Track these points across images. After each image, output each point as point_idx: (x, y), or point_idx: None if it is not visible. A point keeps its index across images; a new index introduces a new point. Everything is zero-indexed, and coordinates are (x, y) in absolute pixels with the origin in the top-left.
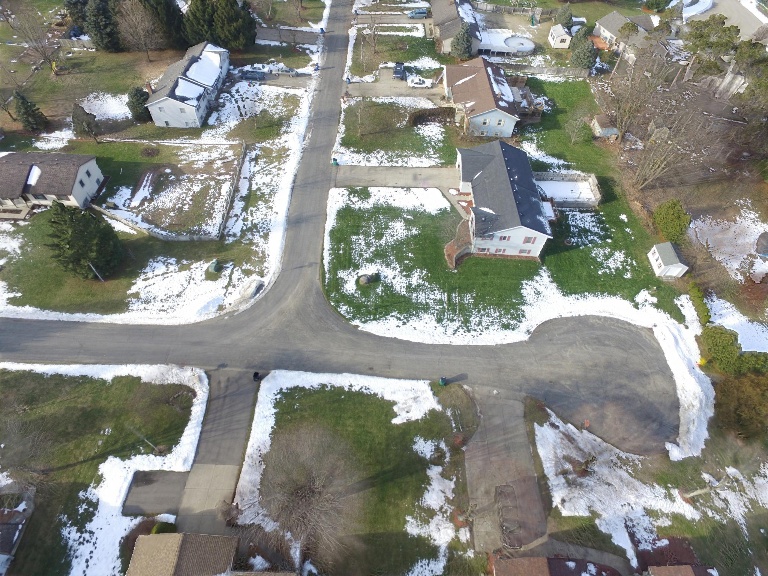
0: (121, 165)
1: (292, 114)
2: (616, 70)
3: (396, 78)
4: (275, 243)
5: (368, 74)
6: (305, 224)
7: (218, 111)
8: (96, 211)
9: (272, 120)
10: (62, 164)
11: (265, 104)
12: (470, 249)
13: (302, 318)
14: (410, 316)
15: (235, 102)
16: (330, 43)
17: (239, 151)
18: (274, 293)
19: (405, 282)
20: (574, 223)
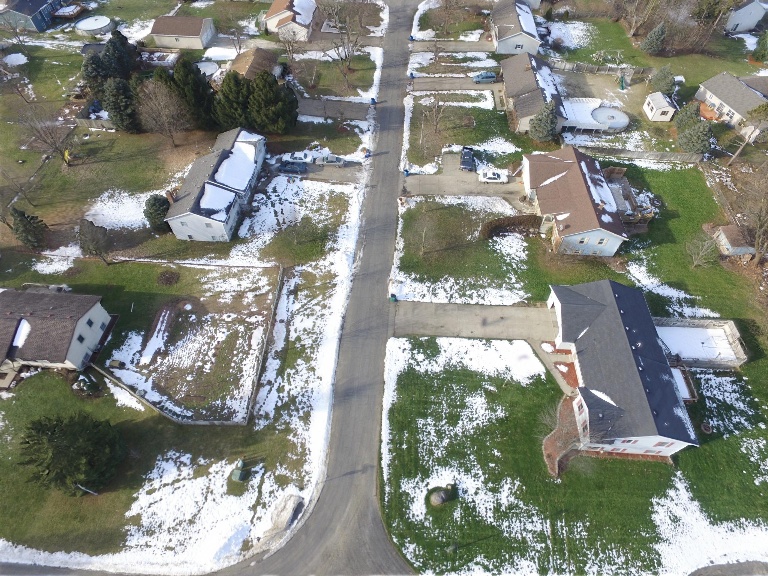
0: (133, 298)
1: (339, 222)
2: (734, 153)
3: (464, 170)
4: (318, 430)
5: (429, 162)
6: (357, 398)
7: (251, 217)
8: (97, 372)
9: (315, 231)
10: (57, 317)
11: (307, 208)
12: (577, 446)
13: (354, 567)
14: (502, 563)
15: (271, 205)
16: (383, 118)
17: (275, 278)
18: (317, 519)
19: (492, 501)
20: (709, 393)
